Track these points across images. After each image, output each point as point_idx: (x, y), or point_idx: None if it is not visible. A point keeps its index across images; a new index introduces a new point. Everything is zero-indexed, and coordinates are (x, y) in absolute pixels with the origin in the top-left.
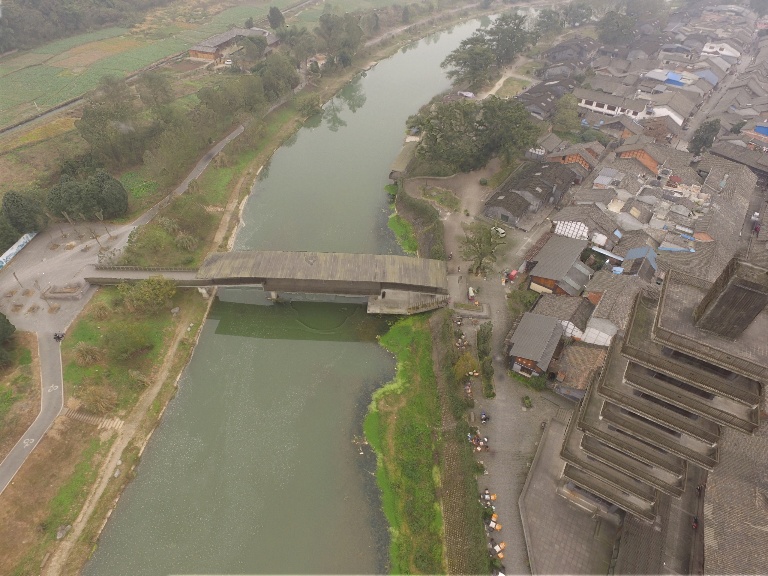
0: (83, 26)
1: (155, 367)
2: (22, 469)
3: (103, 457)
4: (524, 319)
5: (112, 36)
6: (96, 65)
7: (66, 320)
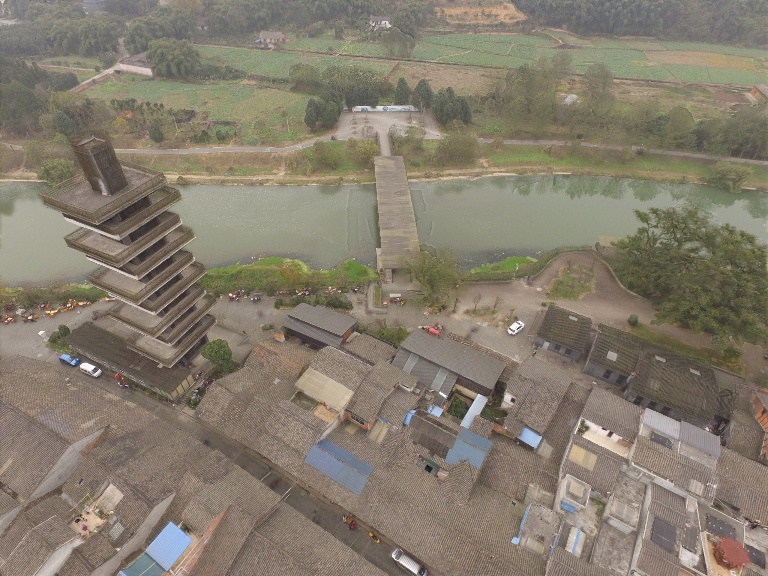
0: (737, 40)
1: (320, 174)
2: (254, 152)
3: (263, 174)
4: (346, 316)
5: (744, 55)
6: (670, 66)
7: (347, 138)
